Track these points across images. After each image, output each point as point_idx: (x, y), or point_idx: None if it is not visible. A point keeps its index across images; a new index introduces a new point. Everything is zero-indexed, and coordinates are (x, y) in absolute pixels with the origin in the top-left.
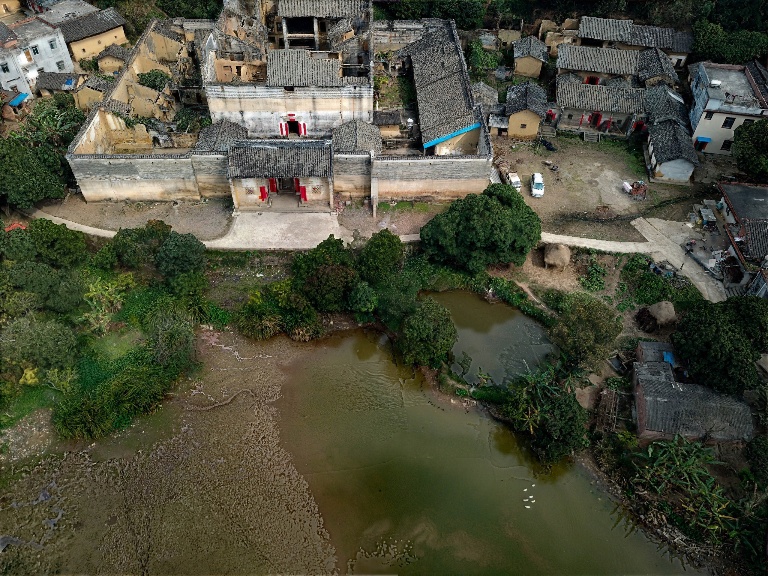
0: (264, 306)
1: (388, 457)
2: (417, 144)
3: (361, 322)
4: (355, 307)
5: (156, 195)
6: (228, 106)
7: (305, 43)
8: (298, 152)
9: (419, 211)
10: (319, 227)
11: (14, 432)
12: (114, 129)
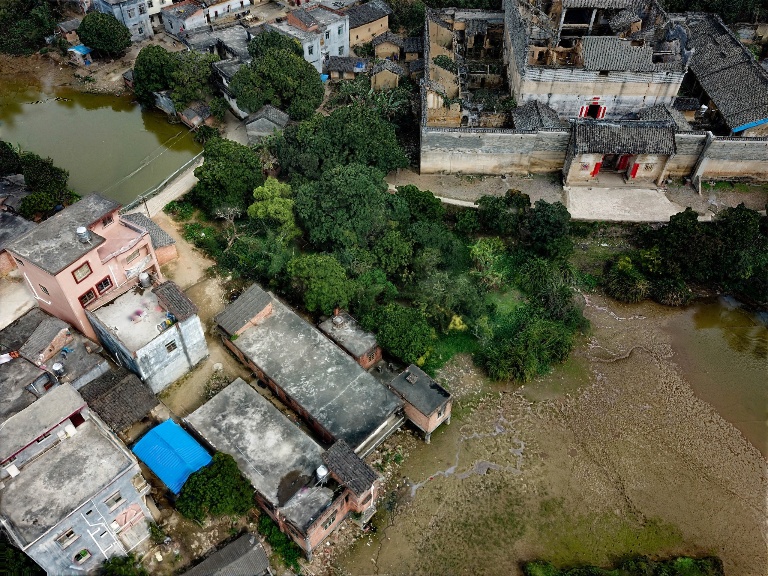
0: (633, 271)
1: None
2: (714, 129)
3: (729, 289)
4: (734, 274)
5: (488, 169)
6: (539, 88)
7: (572, 33)
8: (641, 130)
9: (741, 191)
10: (652, 202)
11: (446, 372)
12: (430, 108)
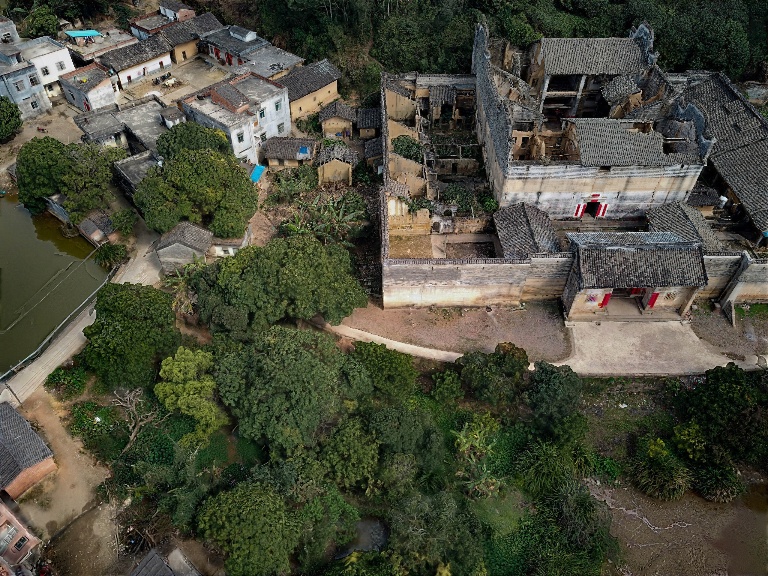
0: (667, 457)
1: None
2: (737, 227)
3: None
4: None
5: (469, 300)
6: (526, 187)
7: (557, 100)
8: (661, 254)
9: None
10: (677, 342)
11: None
12: (392, 215)
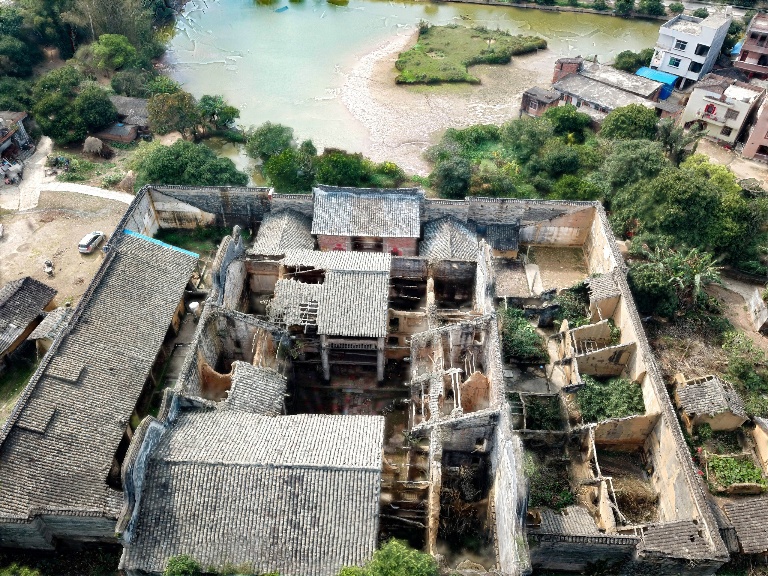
0: (383, 168)
1: (310, 118)
2: None
3: None
4: None
5: None
6: None
7: None
8: None
9: None
10: None
11: None
12: None
